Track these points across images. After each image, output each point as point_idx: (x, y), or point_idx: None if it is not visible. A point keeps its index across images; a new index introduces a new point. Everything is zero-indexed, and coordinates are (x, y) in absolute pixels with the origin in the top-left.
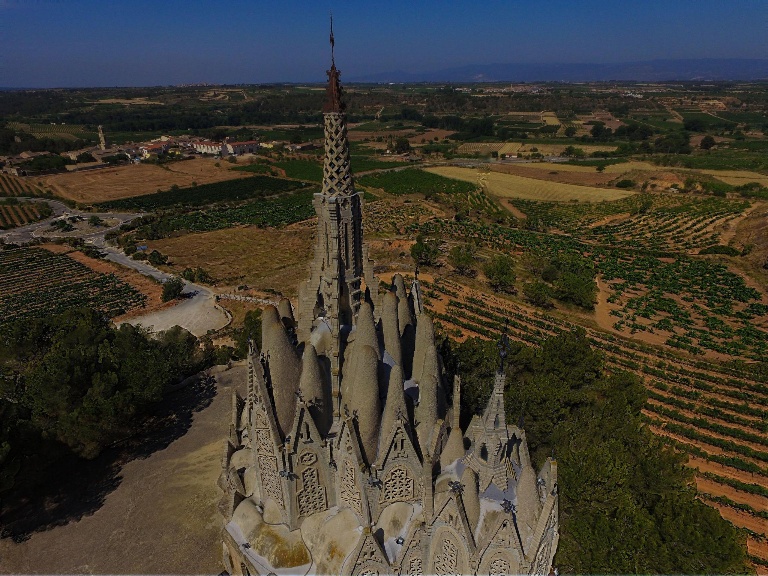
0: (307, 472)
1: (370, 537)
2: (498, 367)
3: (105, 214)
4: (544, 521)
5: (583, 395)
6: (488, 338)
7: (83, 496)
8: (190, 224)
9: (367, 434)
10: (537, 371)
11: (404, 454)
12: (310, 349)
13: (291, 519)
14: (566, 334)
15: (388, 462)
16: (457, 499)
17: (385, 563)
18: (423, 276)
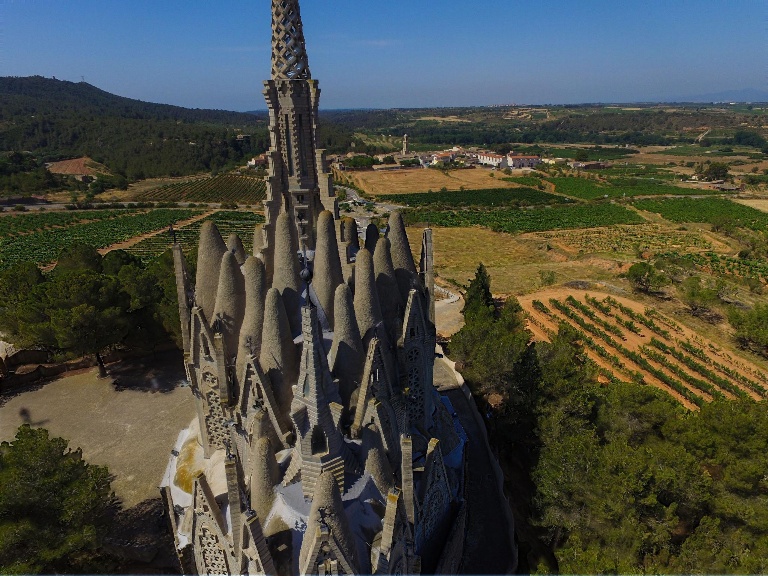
0: (212, 395)
1: (198, 483)
2: (616, 416)
3: (379, 203)
4: (306, 565)
5: (746, 509)
6: (685, 399)
7: (170, 378)
8: (437, 220)
9: (242, 367)
10: (669, 440)
11: (263, 405)
12: (225, 255)
13: (203, 444)
14: (750, 403)
15: (249, 409)
16: (229, 469)
17: (219, 529)
18: (634, 304)
